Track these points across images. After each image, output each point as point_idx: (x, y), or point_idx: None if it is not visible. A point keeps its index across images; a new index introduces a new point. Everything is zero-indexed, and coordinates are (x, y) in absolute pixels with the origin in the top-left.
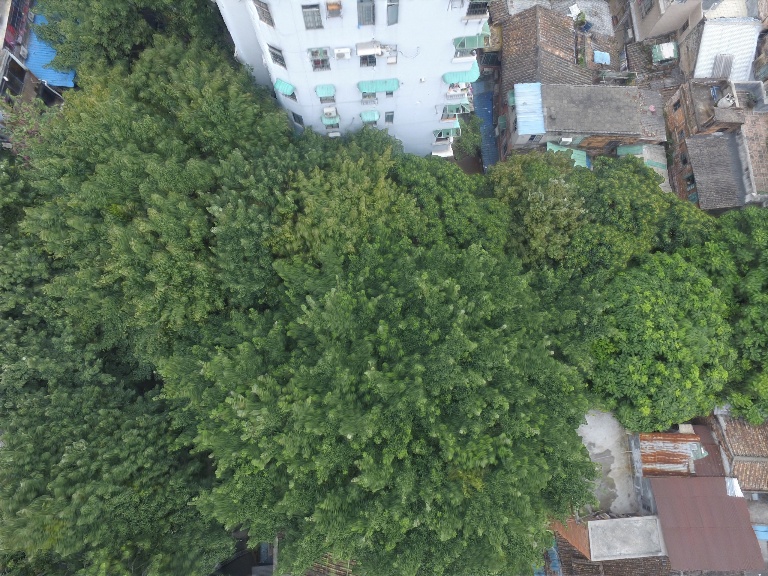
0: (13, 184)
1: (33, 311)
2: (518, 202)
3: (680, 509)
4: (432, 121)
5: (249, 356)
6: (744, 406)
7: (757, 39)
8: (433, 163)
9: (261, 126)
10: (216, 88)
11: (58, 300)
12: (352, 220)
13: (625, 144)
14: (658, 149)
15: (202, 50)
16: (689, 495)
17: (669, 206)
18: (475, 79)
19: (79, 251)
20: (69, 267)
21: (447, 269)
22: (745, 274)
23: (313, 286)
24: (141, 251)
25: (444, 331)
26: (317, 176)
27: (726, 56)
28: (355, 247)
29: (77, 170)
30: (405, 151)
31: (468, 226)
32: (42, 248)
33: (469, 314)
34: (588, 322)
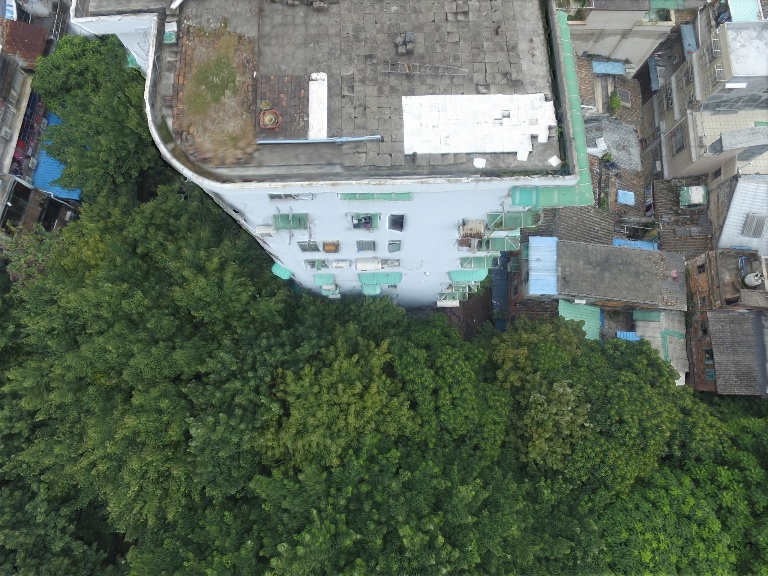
0: (4, 324)
1: (10, 470)
2: (521, 386)
3: None
4: (437, 289)
5: (218, 572)
6: None
7: None
8: (435, 332)
9: (255, 308)
10: (211, 269)
11: None
12: (339, 428)
13: (642, 308)
14: (677, 316)
15: None
16: None
17: None
18: (482, 278)
19: (62, 410)
20: (52, 419)
21: (435, 492)
22: (759, 514)
23: (291, 506)
24: (117, 449)
25: (424, 574)
26: (306, 380)
27: (759, 216)
28: (340, 456)
29: (67, 326)
30: (409, 300)
31: (464, 423)
32: (24, 408)
33: (452, 562)
34: (582, 557)
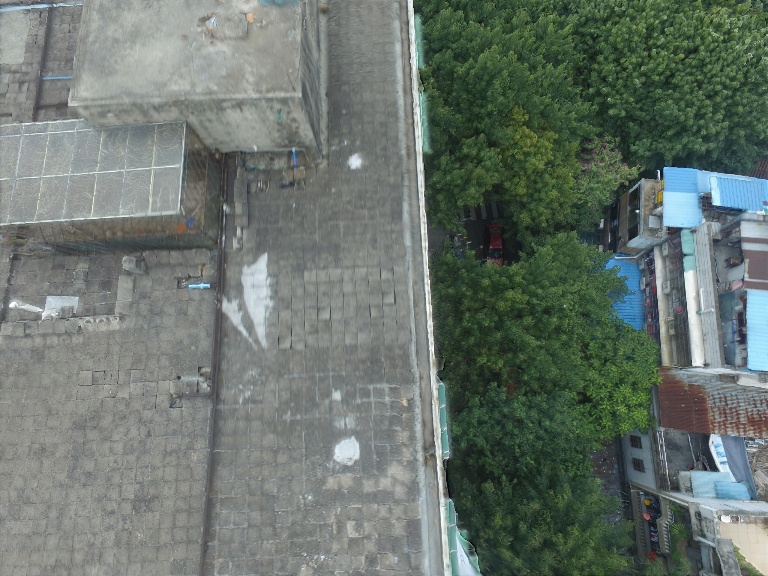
0: (602, 99)
1: None
2: None
3: None
4: None
5: None
6: None
7: None
8: None
9: None
10: None
11: (545, 9)
12: None
13: None
14: None
15: (430, 192)
16: None
17: None
18: None
19: None
20: None
21: None
22: None
23: None
24: None
25: None
26: None
27: None
28: None
29: None
30: None
31: None
32: None
33: None
34: None
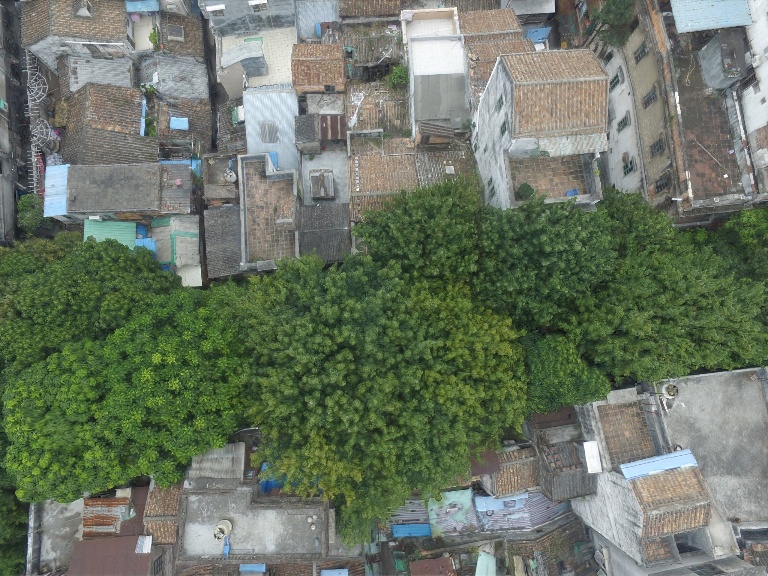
0: None
1: None
2: None
3: (88, 569)
4: None
5: None
6: (146, 474)
7: (297, 104)
8: None
9: None
10: None
11: None
12: None
13: (157, 216)
14: (190, 219)
15: None
16: (101, 555)
17: (98, 295)
18: None
19: None
20: None
21: None
22: None
23: None
24: None
25: None
26: None
27: (268, 123)
28: None
29: None
30: None
31: None
32: None
33: None
34: None
